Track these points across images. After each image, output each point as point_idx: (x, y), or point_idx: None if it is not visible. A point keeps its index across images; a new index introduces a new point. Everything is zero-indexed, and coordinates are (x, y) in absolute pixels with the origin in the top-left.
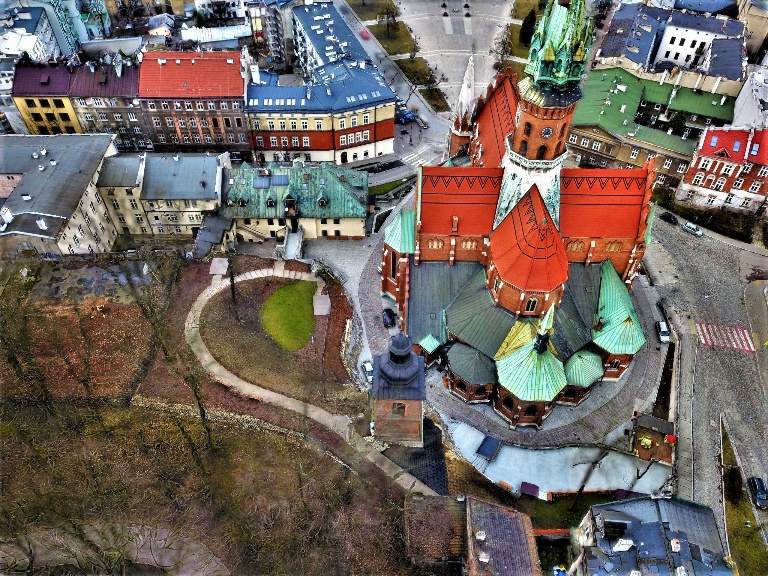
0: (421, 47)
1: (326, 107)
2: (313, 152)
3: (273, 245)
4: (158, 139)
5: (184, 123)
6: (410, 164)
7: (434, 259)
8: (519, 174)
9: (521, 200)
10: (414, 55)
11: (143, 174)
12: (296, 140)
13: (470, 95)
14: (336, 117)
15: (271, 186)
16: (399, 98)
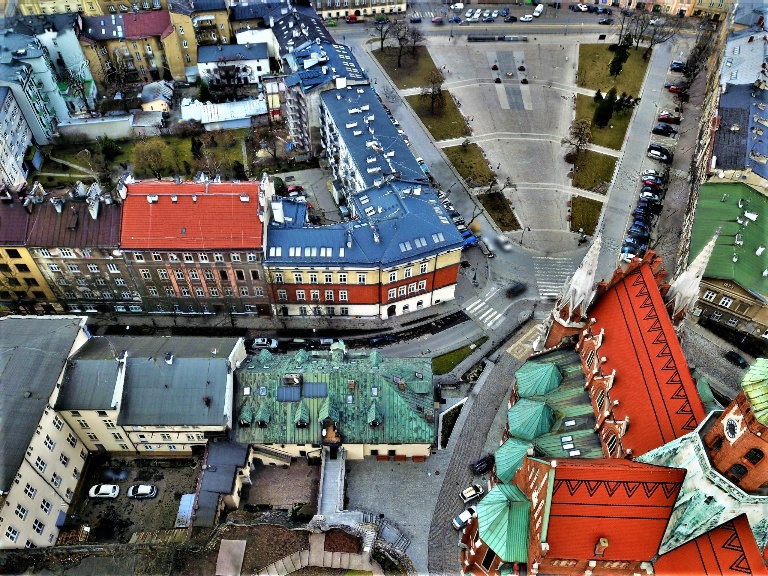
0: (473, 128)
1: (373, 259)
2: (352, 306)
3: (303, 471)
4: (148, 291)
5: (182, 275)
6: (477, 318)
7: (557, 573)
8: (721, 500)
9: (716, 530)
10: (467, 143)
11: (122, 385)
12: (330, 293)
13: (589, 282)
14: (385, 270)
15: (302, 398)
16: (453, 208)
